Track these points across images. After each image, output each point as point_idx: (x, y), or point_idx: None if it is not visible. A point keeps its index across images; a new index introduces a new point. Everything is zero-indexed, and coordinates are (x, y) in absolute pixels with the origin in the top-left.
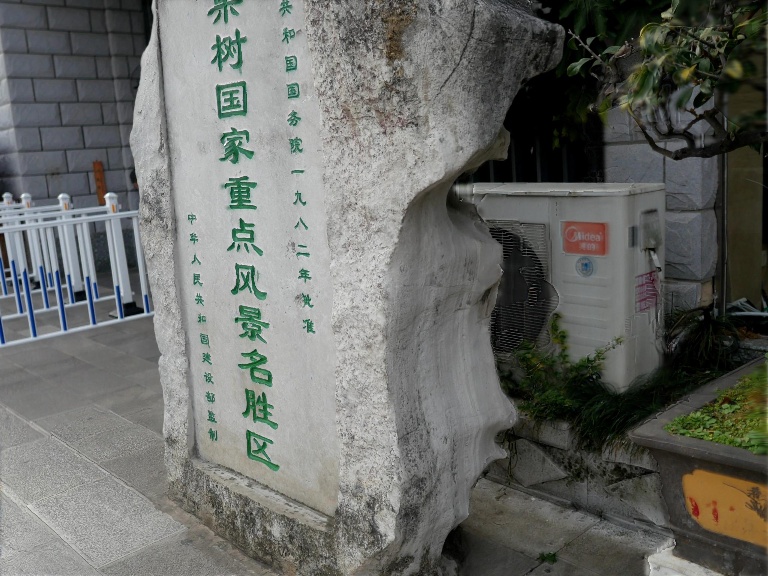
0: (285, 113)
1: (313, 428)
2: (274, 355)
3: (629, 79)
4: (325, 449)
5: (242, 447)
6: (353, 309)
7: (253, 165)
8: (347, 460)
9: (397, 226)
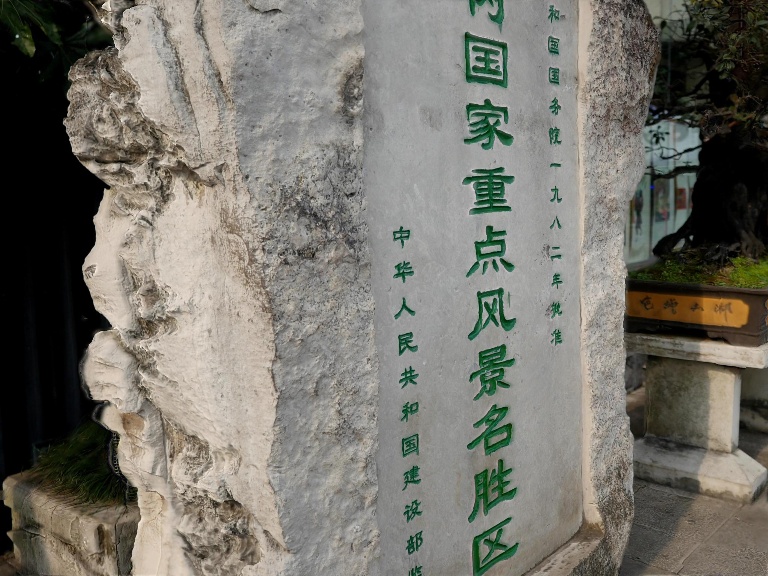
0: (548, 98)
1: (556, 454)
2: (517, 397)
3: (716, 126)
4: (566, 468)
5: (467, 573)
6: None
7: None
8: (597, 453)
9: None
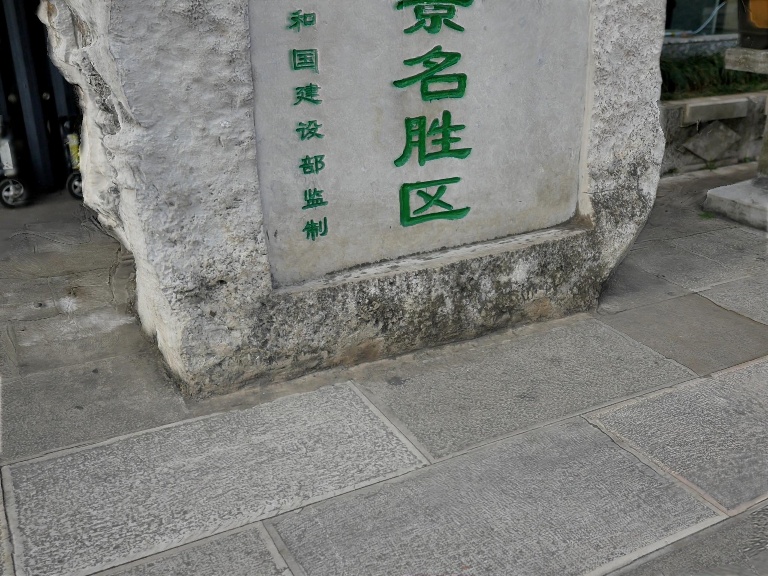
0: None
1: (538, 126)
2: (477, 45)
3: None
4: (553, 146)
5: (390, 217)
6: None
7: None
8: (601, 138)
9: None
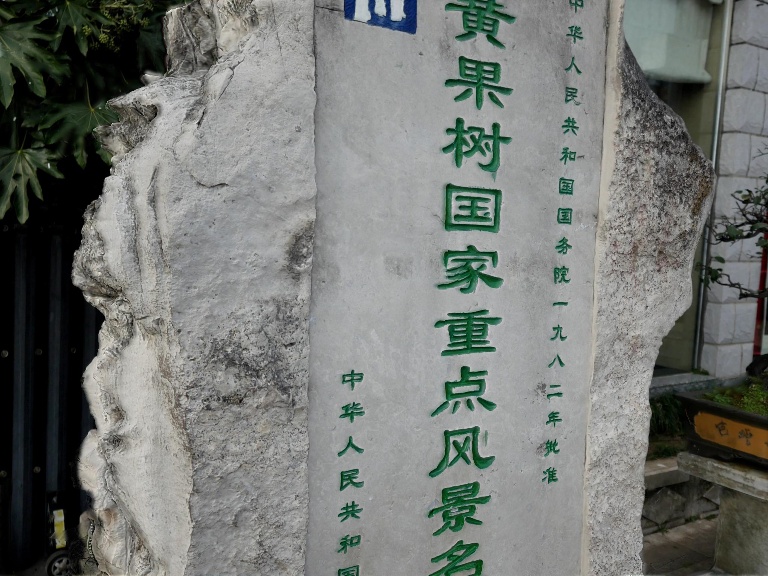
0: (554, 238)
1: None
2: (492, 534)
3: None
4: None
5: None
6: (621, 436)
7: (501, 296)
8: None
9: (656, 350)
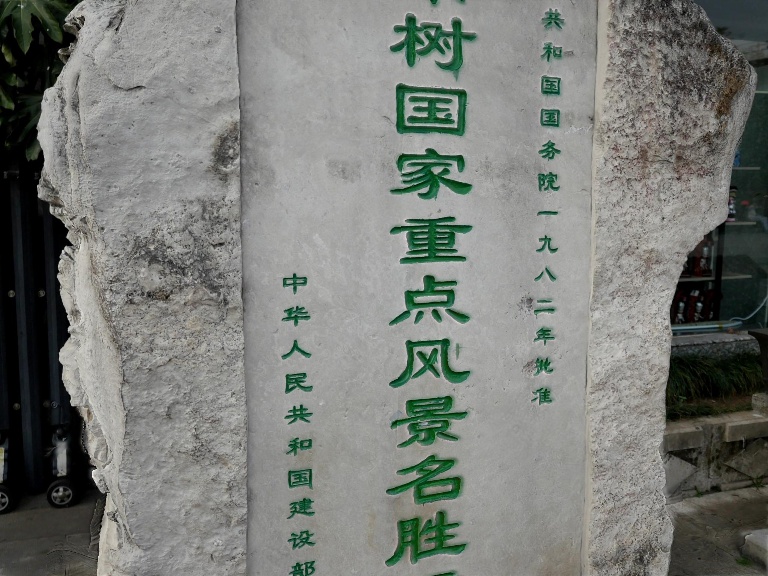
0: (536, 142)
1: (535, 520)
2: (470, 452)
3: None
4: (552, 537)
5: None
6: (630, 359)
7: (469, 202)
8: (602, 530)
9: (679, 268)
